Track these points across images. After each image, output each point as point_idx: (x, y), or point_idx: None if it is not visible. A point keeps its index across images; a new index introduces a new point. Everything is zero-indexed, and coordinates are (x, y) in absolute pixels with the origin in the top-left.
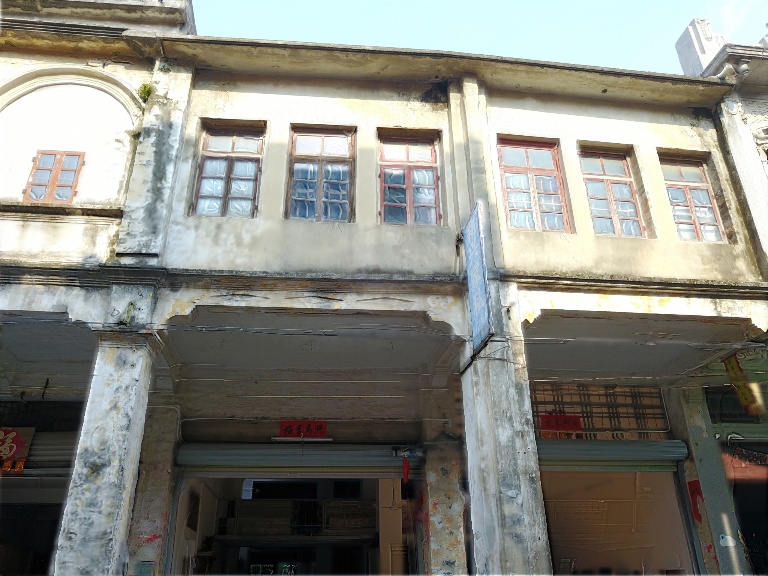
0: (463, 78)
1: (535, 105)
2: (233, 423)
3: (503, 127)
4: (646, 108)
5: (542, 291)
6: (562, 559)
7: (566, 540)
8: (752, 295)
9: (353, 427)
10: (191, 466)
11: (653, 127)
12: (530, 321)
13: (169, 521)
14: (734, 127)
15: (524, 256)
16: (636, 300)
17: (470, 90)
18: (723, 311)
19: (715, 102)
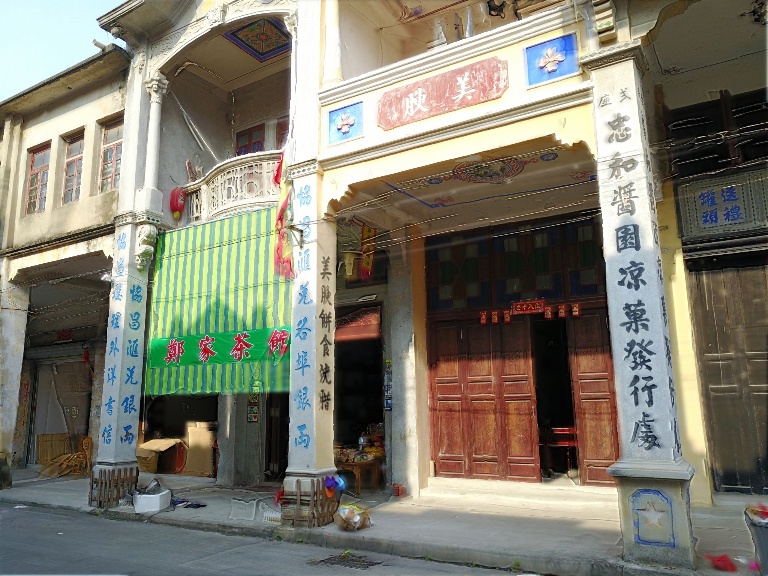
0: (5, 119)
1: (46, 116)
2: (44, 335)
3: (29, 143)
4: (98, 86)
5: (19, 258)
6: (182, 403)
7: (180, 392)
8: (104, 232)
9: (80, 332)
10: (34, 359)
11: (97, 103)
12: (12, 279)
13: (29, 386)
14: (132, 81)
15: (22, 235)
16: (54, 252)
17: (6, 127)
18: (91, 248)
19: (126, 61)
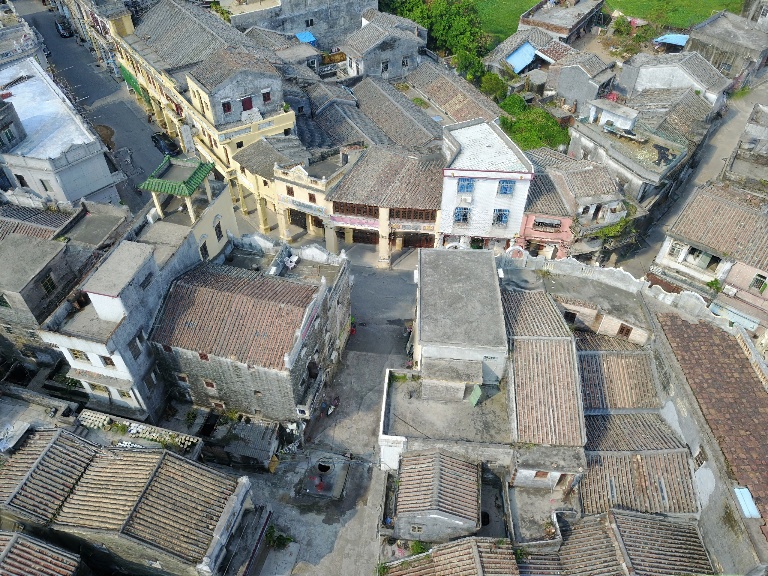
0: None
1: None
2: None
3: None
4: None
5: None
6: None
7: None
8: None
9: None
10: None
11: None
12: None
13: None
14: None
15: None
16: None
17: None
18: None
19: None
